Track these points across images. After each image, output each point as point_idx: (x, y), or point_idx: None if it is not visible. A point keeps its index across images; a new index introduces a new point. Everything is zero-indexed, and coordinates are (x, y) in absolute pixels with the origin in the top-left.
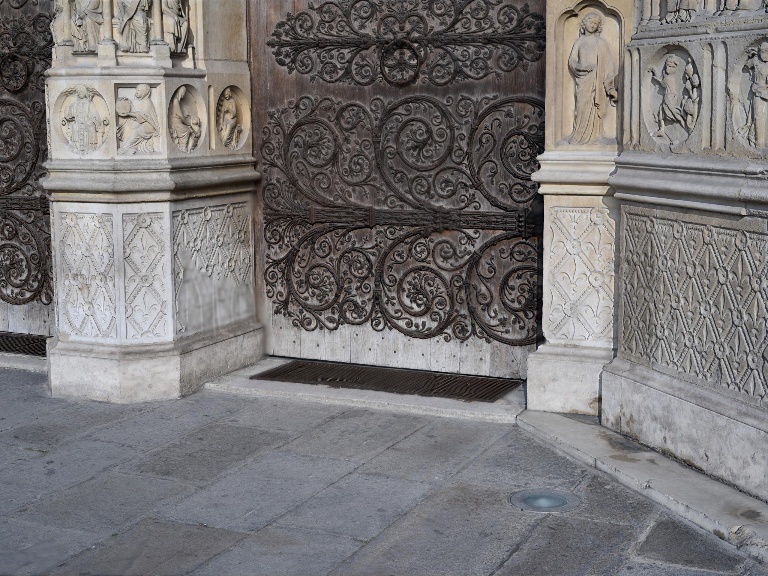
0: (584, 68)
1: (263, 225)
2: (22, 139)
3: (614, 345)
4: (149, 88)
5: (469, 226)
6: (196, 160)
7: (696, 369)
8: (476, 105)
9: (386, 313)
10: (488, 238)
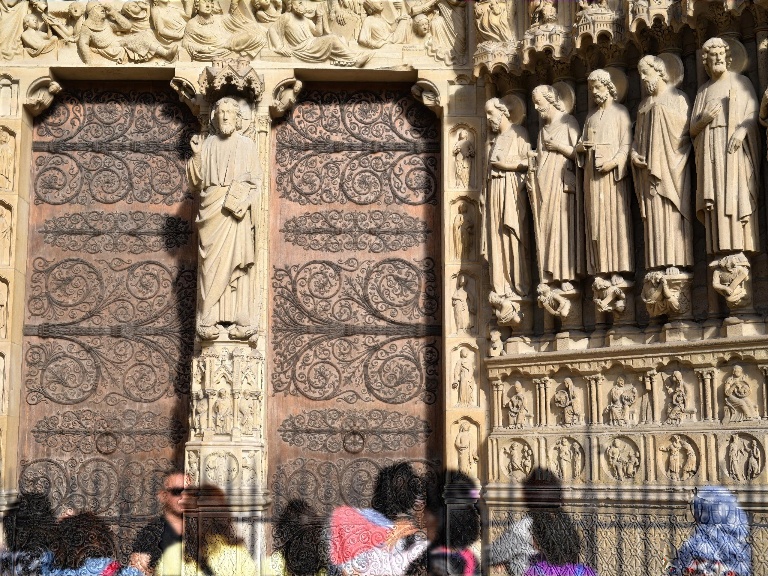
0: (465, 446)
1: (271, 528)
2: (109, 481)
3: (482, 574)
4: None
5: (392, 524)
6: None
7: (538, 574)
8: (395, 463)
9: (345, 572)
10: (401, 529)
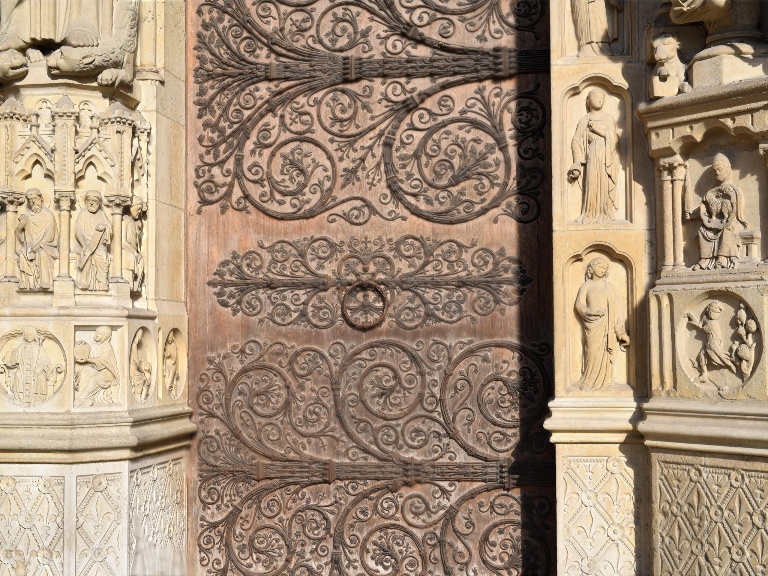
0: (596, 313)
1: (197, 483)
2: None
3: None
4: (110, 331)
5: (444, 478)
6: (149, 411)
7: None
8: (450, 350)
9: None
10: (465, 491)
